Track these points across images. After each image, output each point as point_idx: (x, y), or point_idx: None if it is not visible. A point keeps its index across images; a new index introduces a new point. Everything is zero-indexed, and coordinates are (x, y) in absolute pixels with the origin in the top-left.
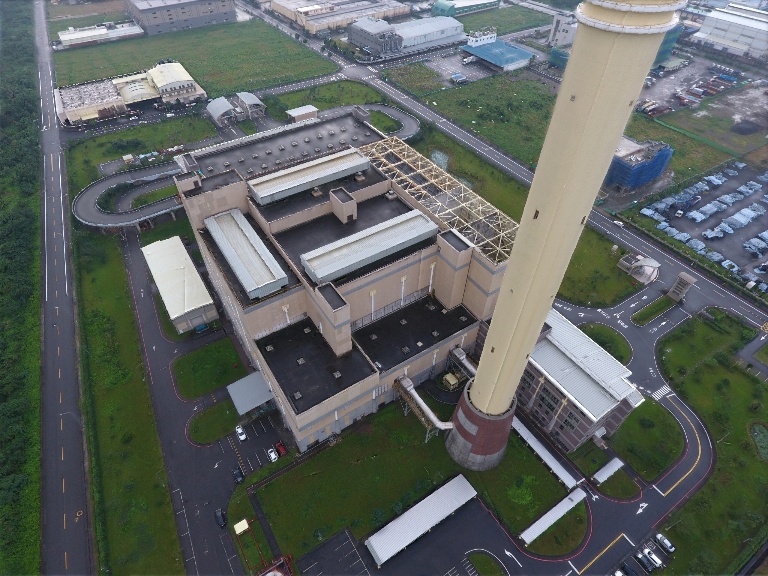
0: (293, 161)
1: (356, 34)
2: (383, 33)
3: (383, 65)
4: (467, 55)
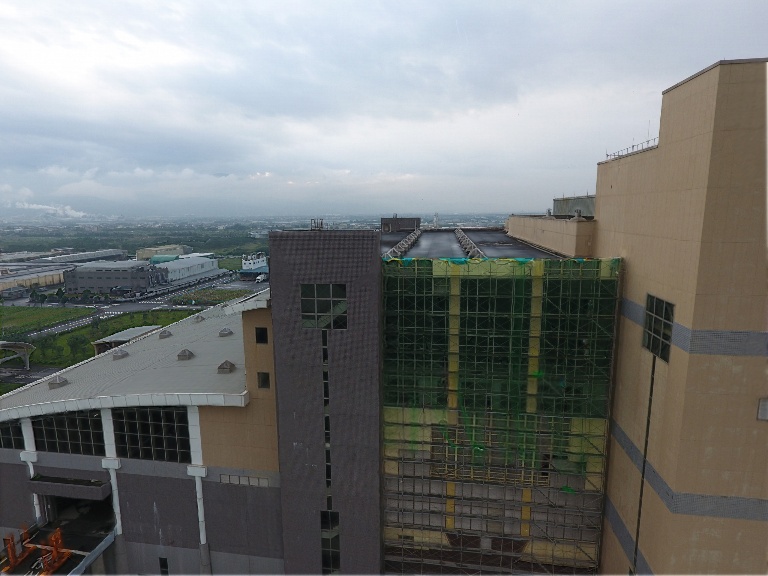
0: (478, 244)
1: (87, 278)
2: (139, 267)
3: (161, 298)
4: (248, 279)
